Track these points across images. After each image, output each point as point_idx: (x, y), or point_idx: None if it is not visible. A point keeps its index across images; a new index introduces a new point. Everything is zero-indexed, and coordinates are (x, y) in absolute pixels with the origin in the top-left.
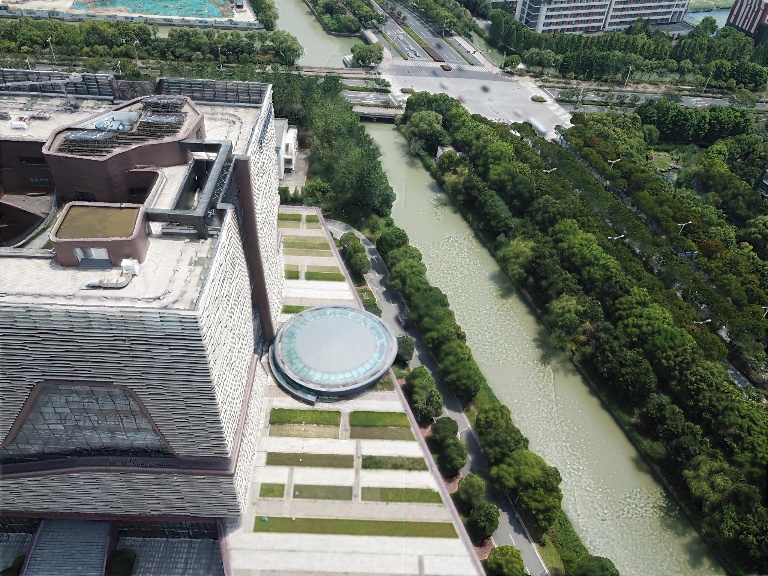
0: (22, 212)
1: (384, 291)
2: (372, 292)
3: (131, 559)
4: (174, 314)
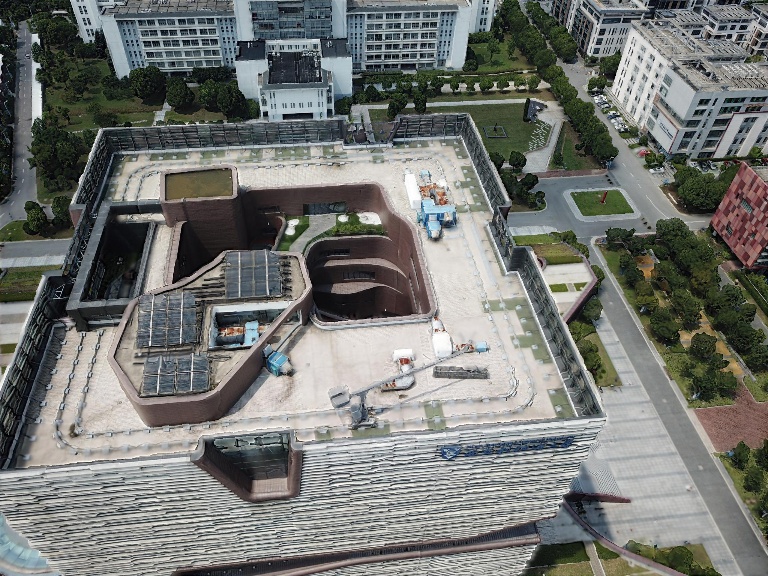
0: None
1: None
2: None
3: None
4: None
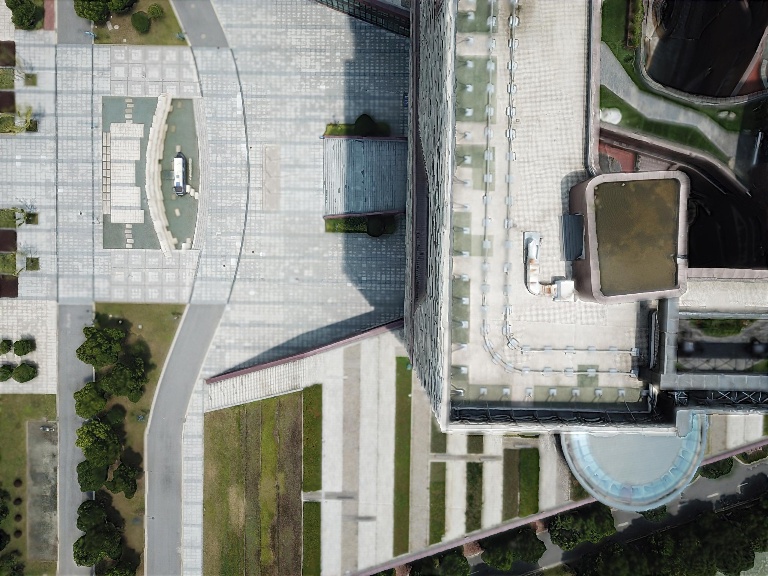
0: (761, 31)
1: (766, 475)
2: (763, 459)
3: (387, 231)
4: (442, 398)
